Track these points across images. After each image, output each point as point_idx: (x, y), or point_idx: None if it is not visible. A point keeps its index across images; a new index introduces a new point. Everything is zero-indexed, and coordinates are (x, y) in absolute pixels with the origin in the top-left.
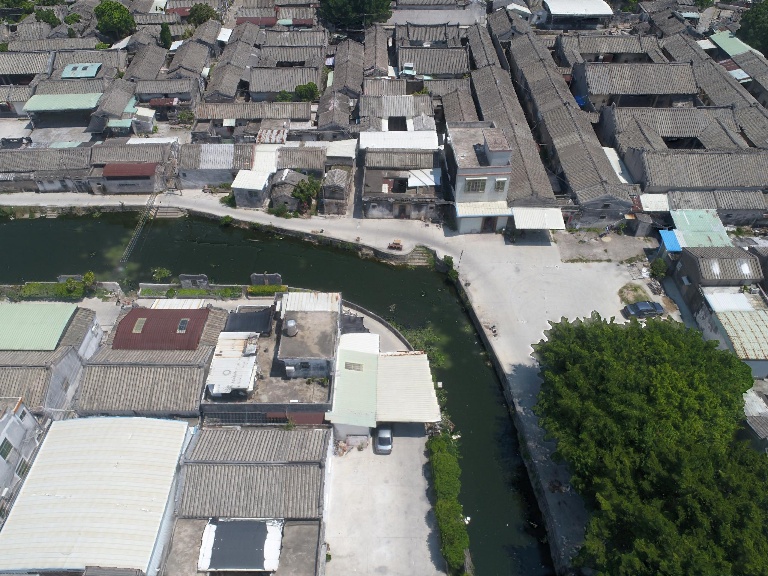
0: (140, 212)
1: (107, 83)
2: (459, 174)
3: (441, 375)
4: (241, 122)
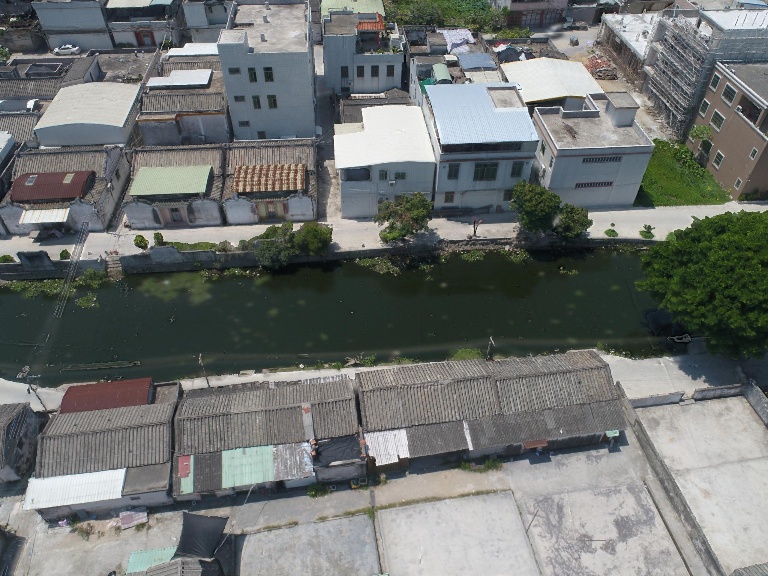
0: None
1: None
2: None
3: None
4: None
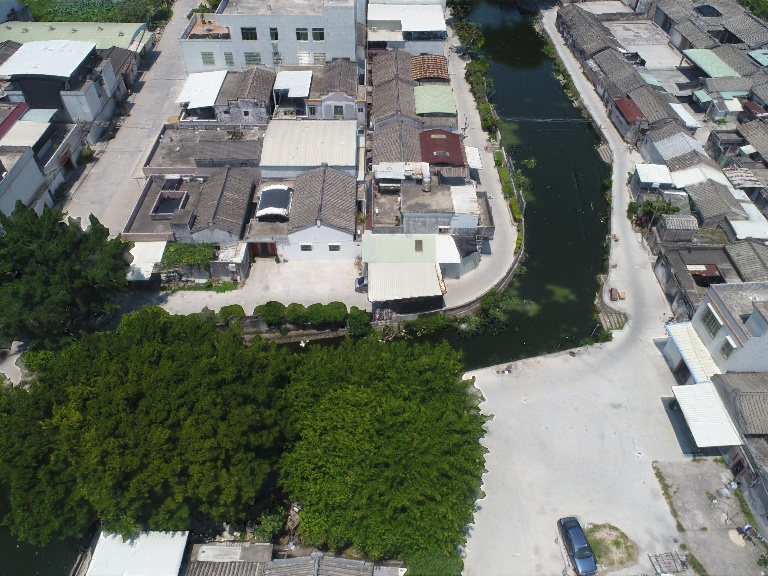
0: (601, 141)
1: (761, 75)
2: (708, 292)
3: (450, 338)
4: (761, 159)
